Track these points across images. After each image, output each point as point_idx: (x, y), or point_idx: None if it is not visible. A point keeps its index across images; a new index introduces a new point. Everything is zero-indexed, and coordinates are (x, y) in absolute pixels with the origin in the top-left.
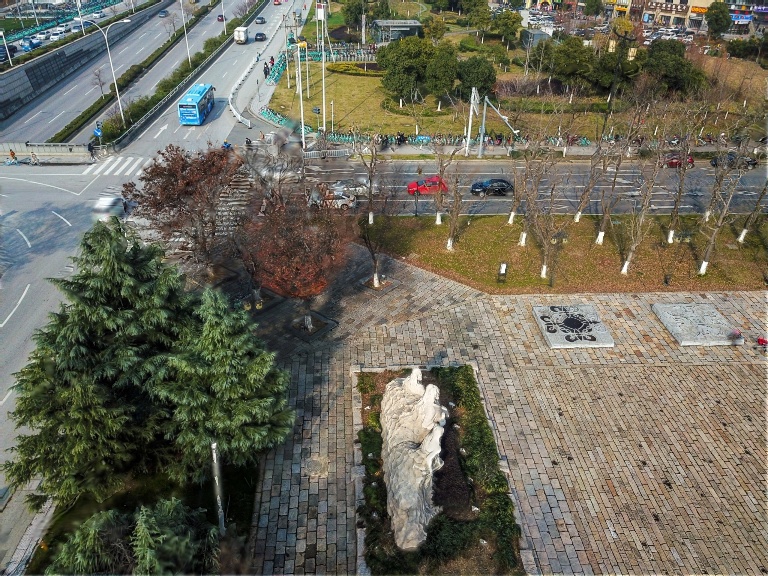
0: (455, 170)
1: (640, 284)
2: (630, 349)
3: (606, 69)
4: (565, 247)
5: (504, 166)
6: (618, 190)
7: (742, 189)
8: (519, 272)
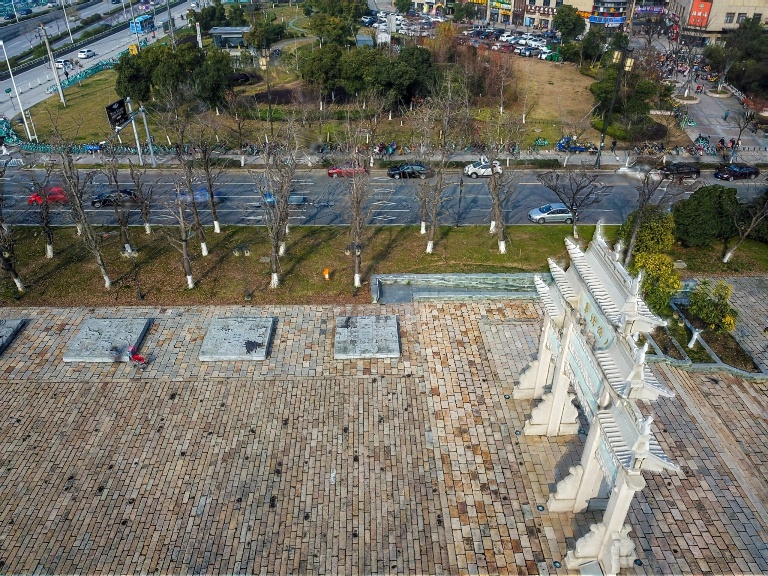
0: (113, 180)
1: (113, 298)
2: (7, 365)
3: (259, 78)
4: (90, 259)
5: (167, 175)
6: (252, 200)
7: (385, 199)
8: (8, 285)
